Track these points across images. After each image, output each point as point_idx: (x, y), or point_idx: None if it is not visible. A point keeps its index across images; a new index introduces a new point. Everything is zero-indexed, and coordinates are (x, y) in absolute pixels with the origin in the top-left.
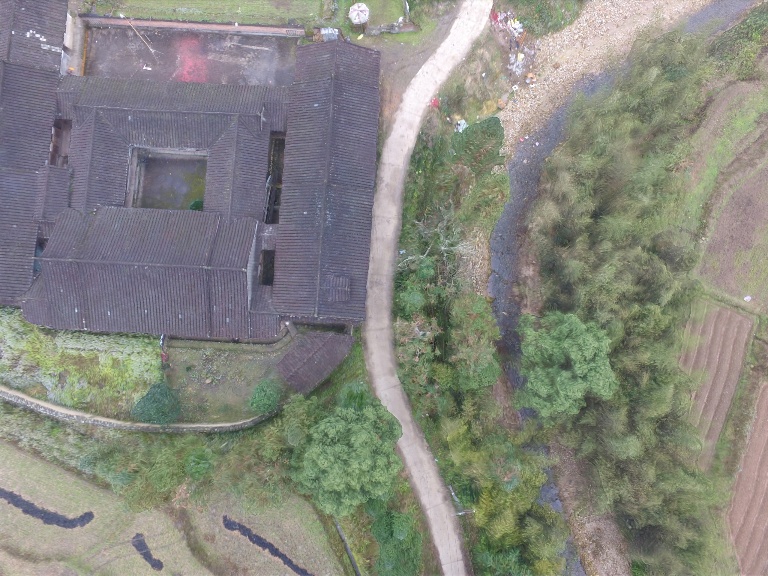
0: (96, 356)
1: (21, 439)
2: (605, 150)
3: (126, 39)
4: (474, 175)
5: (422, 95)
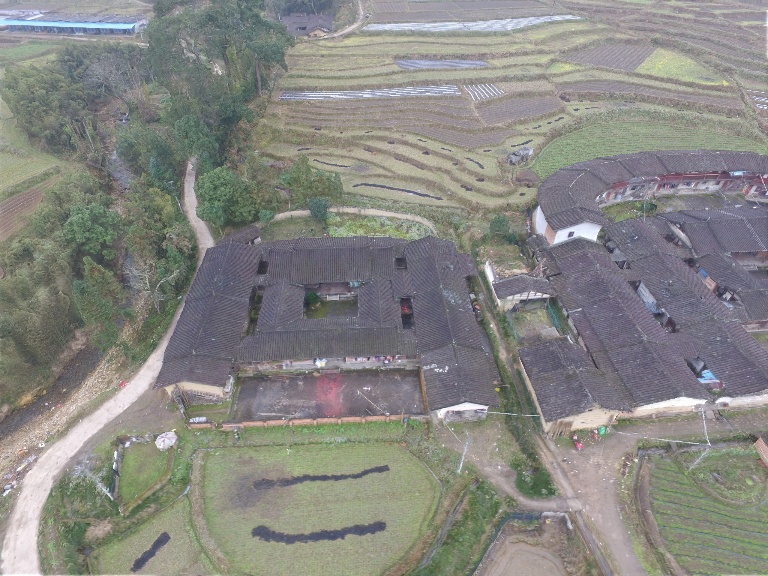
0: (366, 234)
1: (394, 203)
2: (2, 327)
3: (390, 411)
4: (113, 372)
5: (131, 390)
